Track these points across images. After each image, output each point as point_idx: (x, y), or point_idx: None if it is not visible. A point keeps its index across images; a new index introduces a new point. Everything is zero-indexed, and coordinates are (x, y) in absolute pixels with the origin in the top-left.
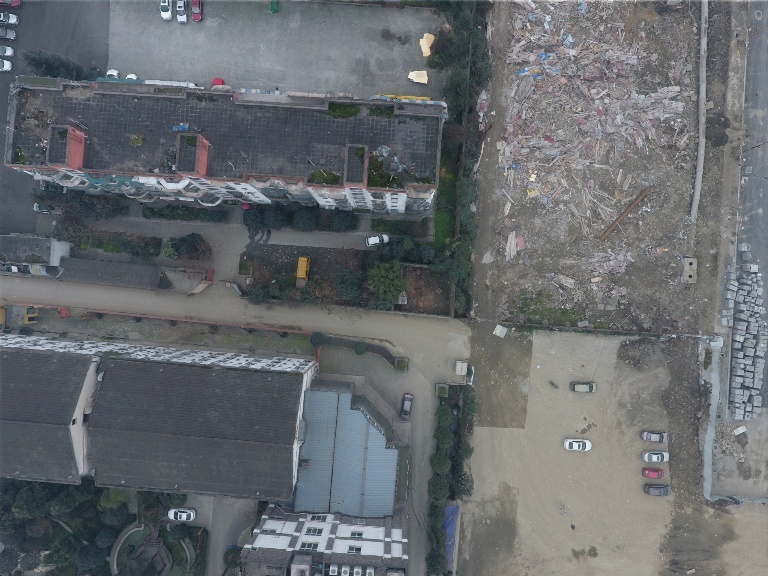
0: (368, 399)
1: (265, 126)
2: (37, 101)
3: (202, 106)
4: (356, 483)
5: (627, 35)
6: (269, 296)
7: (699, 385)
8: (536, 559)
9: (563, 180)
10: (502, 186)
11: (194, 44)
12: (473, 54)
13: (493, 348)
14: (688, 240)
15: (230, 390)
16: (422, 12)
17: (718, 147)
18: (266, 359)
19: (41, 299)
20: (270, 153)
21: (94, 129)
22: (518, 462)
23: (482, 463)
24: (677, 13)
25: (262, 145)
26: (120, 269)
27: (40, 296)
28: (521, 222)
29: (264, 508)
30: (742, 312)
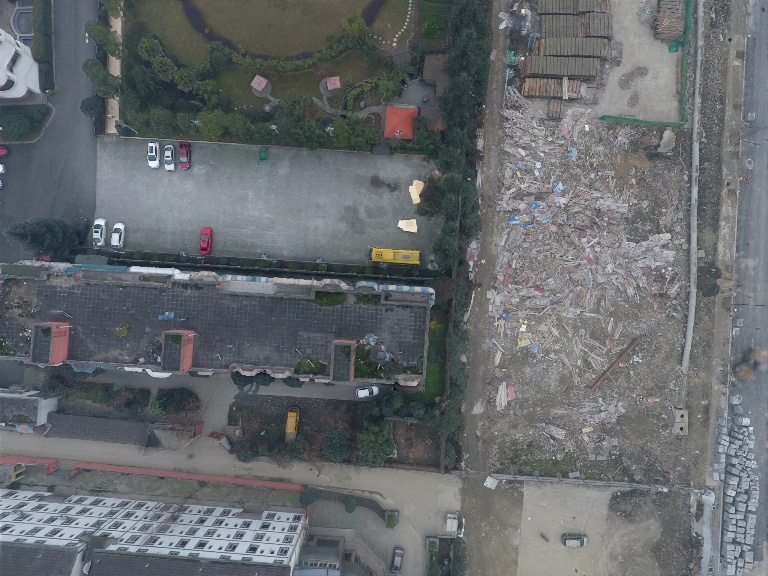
0: (358, 554)
1: (251, 314)
2: (21, 289)
3: (188, 294)
4: None
5: (618, 182)
6: (258, 454)
7: (691, 536)
8: None
9: (554, 329)
10: (492, 335)
11: (182, 192)
12: (463, 205)
13: (484, 500)
14: (679, 391)
15: None
16: (411, 159)
17: (709, 297)
18: (255, 520)
19: (29, 451)
20: (256, 342)
21: (79, 318)
22: None
23: None
24: (668, 160)
25: (248, 334)
26: (108, 425)
27: (28, 448)
28: (512, 372)
29: None
30: (734, 466)
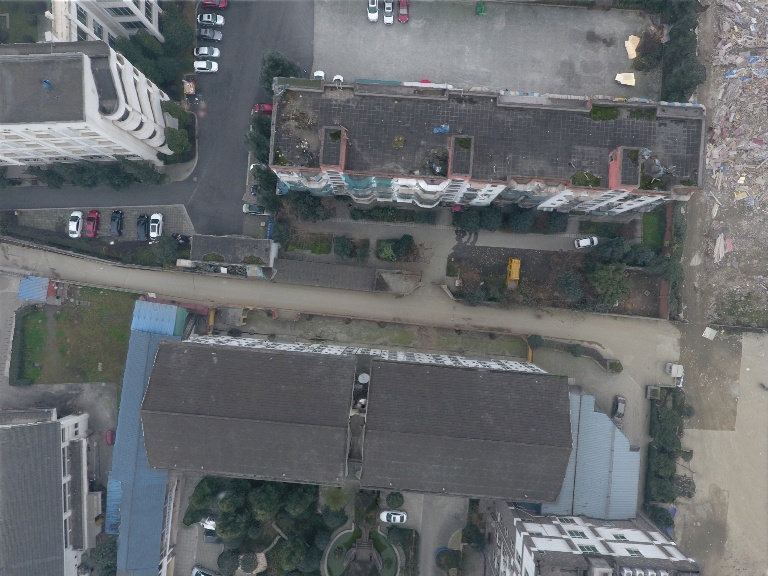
0: None
1: (526, 128)
2: (297, 102)
3: (462, 108)
4: (601, 486)
5: None
6: (486, 298)
7: None
8: (747, 562)
9: None
10: (709, 188)
11: (399, 46)
12: None
13: (702, 350)
14: None
15: (499, 392)
16: (627, 14)
17: None
18: (486, 361)
19: (248, 300)
20: (531, 155)
21: (354, 131)
22: (728, 464)
23: (692, 465)
24: None
25: (523, 147)
26: (334, 271)
27: (247, 297)
28: (728, 224)
29: (475, 510)
30: None
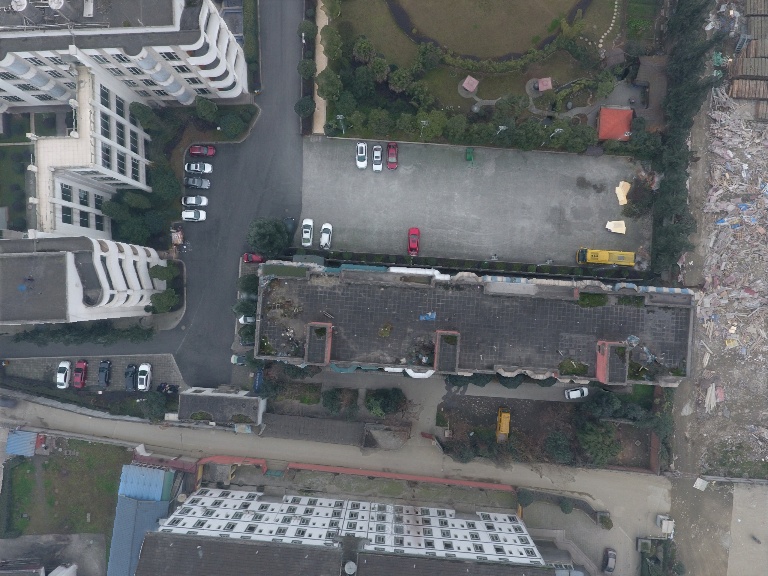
0: None
1: (513, 315)
2: (282, 290)
3: (449, 295)
4: None
5: None
6: (476, 455)
7: None
8: None
9: (762, 331)
10: (700, 337)
11: (388, 192)
12: None
13: (693, 501)
14: None
15: None
16: (618, 160)
17: None
18: (475, 520)
19: (237, 451)
20: (518, 343)
21: (340, 318)
22: None
23: None
24: None
25: (510, 335)
26: (323, 425)
27: (236, 448)
28: (720, 373)
29: None
30: None
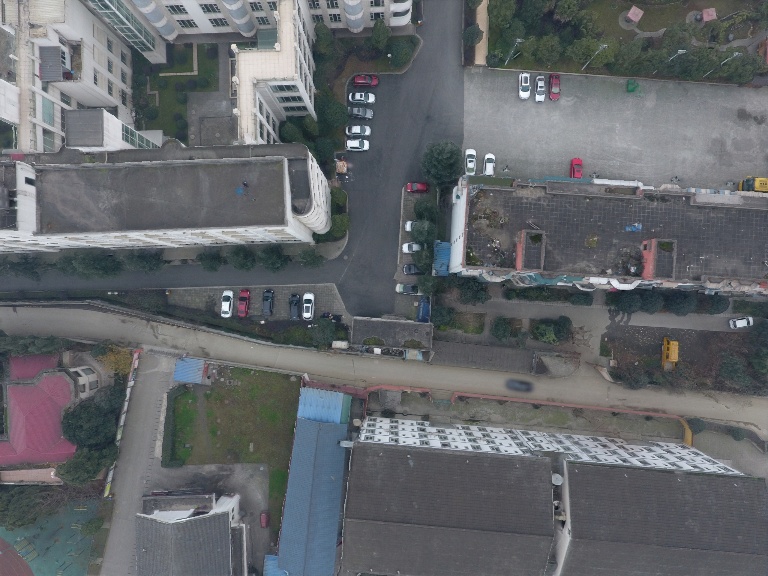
0: None
1: (718, 227)
2: (488, 201)
3: (654, 206)
4: None
5: None
6: None
7: None
8: None
9: None
10: None
11: (550, 123)
12: None
13: None
14: None
15: (699, 497)
16: None
17: None
18: (650, 446)
19: (401, 380)
20: (724, 254)
21: (546, 229)
22: None
23: None
24: None
25: (716, 246)
26: (491, 353)
27: (399, 377)
28: None
29: None
30: None
